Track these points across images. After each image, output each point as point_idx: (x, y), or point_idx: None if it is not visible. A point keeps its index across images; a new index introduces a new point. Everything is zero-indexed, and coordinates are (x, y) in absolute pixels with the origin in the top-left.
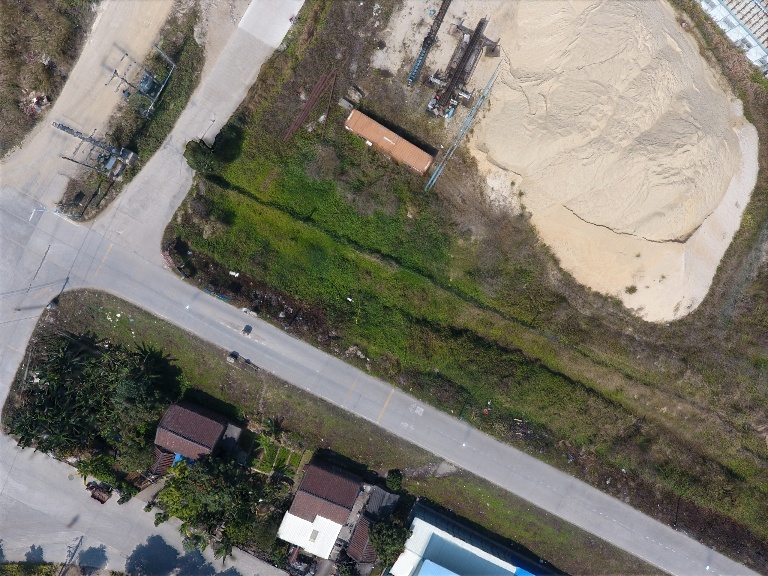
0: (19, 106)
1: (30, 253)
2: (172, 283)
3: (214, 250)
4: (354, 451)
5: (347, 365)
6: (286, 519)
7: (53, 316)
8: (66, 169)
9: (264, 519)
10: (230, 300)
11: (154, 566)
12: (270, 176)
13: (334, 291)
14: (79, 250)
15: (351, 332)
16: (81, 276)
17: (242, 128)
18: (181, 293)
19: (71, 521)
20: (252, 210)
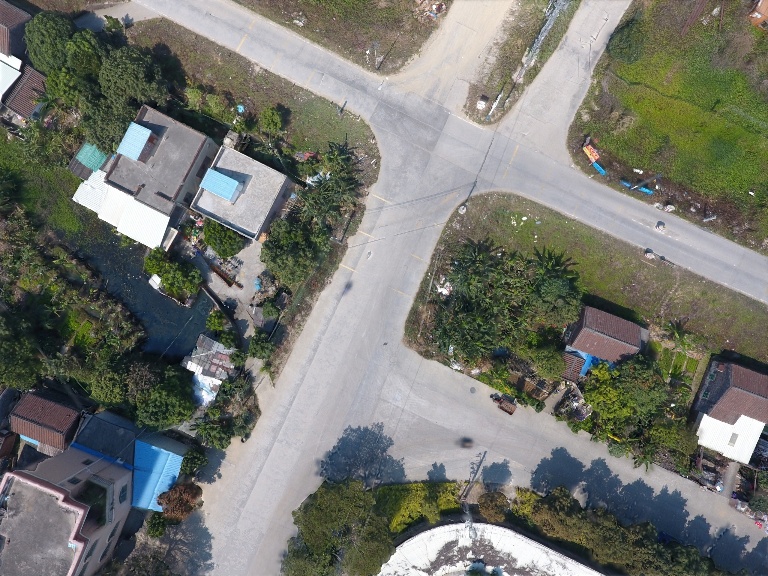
0: (413, 16)
1: (437, 159)
2: (580, 182)
3: (618, 148)
4: (762, 351)
5: (764, 257)
6: (704, 423)
7: (460, 222)
8: (464, 74)
9: (682, 423)
10: (642, 196)
11: (559, 480)
12: (672, 70)
13: (736, 185)
14: (486, 153)
15: (765, 224)
16: (489, 179)
17: (640, 24)
18: (590, 192)
19: (474, 436)
20: (653, 106)
